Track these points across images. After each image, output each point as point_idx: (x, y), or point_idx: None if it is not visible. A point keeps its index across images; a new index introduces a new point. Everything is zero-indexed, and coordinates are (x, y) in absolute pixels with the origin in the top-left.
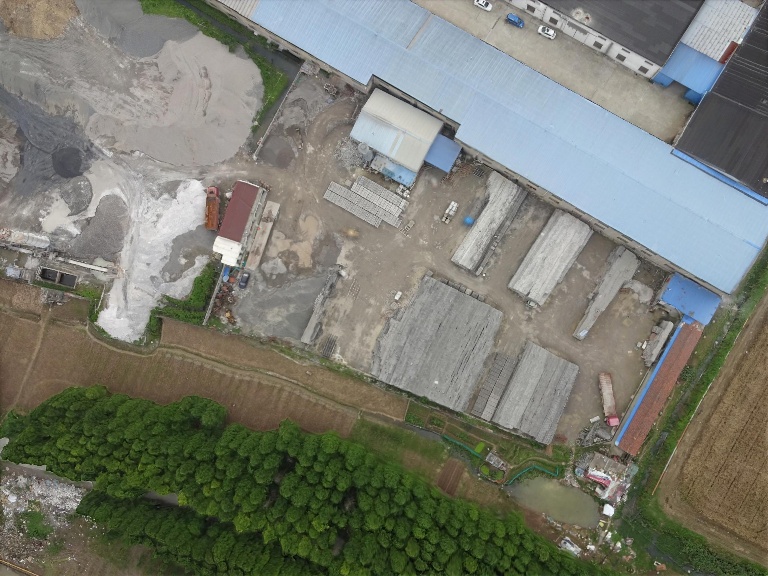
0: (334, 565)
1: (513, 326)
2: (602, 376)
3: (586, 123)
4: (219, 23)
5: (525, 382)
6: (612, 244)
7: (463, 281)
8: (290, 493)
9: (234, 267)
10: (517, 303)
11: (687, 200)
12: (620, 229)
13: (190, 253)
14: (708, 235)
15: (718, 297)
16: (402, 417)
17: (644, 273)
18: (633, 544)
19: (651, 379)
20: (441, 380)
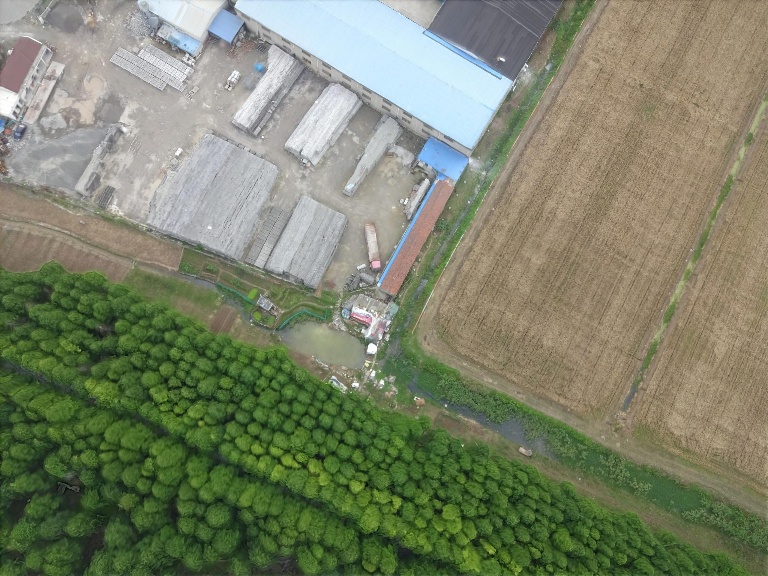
0: (78, 379)
1: (288, 183)
2: (367, 226)
3: (351, 3)
4: None
5: (296, 229)
6: (379, 115)
7: (243, 142)
8: (38, 313)
9: (10, 119)
10: (293, 163)
11: (435, 70)
12: (379, 92)
13: None
14: (452, 99)
15: (466, 157)
16: (177, 266)
17: (406, 141)
18: (395, 381)
19: (410, 228)
20: (214, 226)
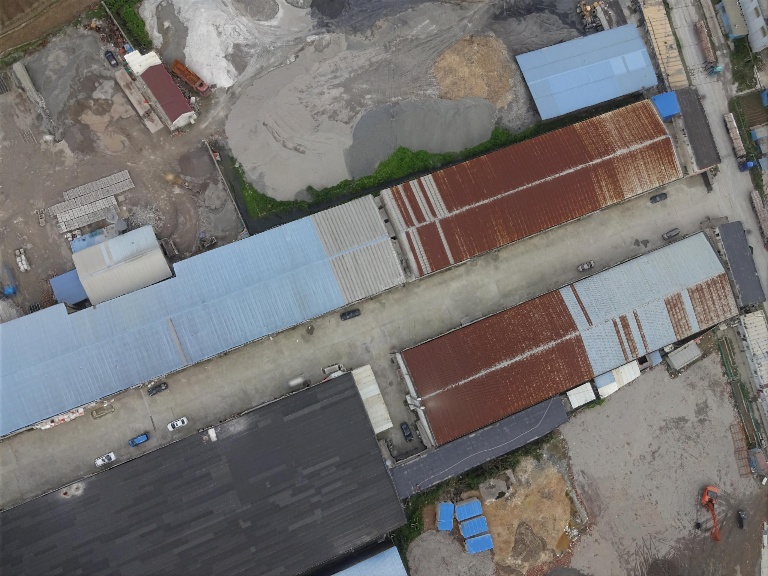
0: None
1: None
2: None
3: None
4: (347, 199)
5: None
6: None
7: None
8: None
9: None
10: None
11: None
12: None
13: (167, 34)
14: None
15: None
16: None
17: None
18: None
19: None
20: None
